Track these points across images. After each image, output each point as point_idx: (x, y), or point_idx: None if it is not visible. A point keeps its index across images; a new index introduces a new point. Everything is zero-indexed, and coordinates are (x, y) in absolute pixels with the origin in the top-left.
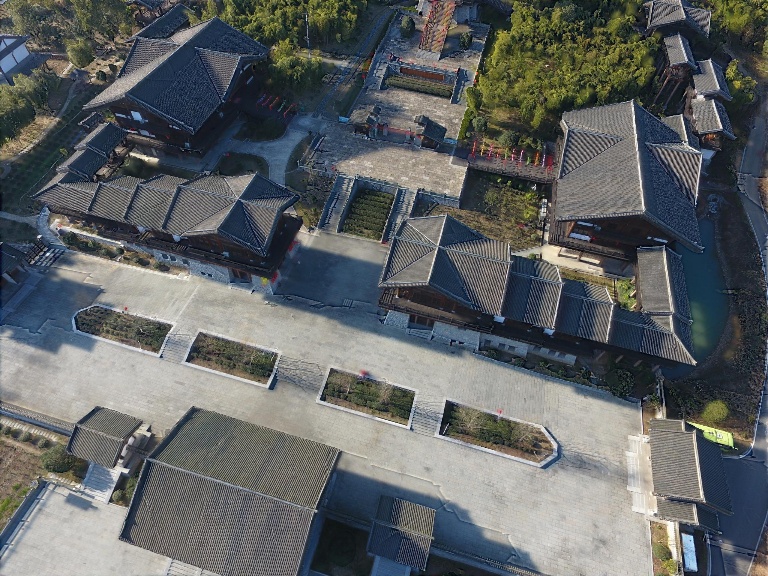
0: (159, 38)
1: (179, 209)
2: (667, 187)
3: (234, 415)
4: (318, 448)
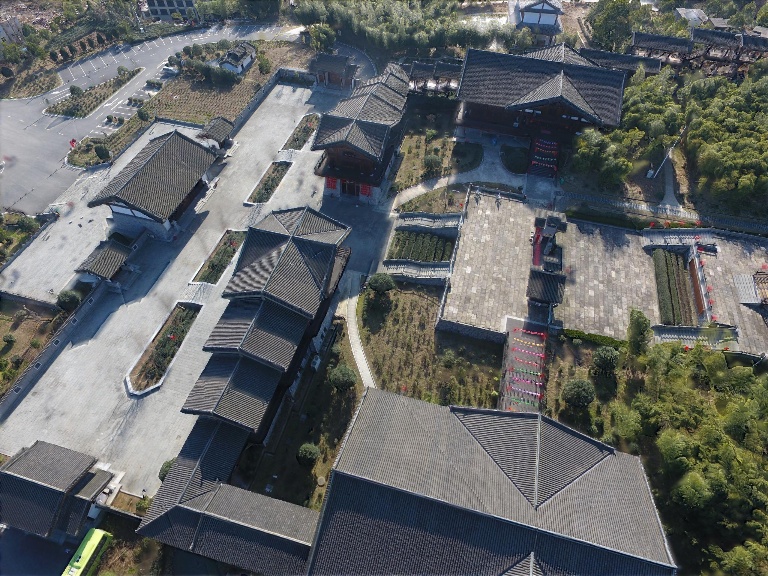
0: (586, 59)
1: (353, 101)
2: (429, 574)
3: (229, 190)
4: (169, 210)
